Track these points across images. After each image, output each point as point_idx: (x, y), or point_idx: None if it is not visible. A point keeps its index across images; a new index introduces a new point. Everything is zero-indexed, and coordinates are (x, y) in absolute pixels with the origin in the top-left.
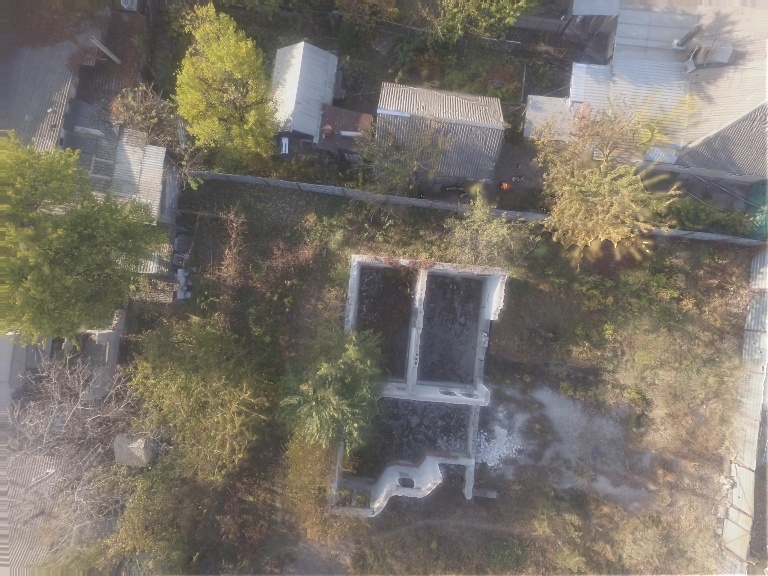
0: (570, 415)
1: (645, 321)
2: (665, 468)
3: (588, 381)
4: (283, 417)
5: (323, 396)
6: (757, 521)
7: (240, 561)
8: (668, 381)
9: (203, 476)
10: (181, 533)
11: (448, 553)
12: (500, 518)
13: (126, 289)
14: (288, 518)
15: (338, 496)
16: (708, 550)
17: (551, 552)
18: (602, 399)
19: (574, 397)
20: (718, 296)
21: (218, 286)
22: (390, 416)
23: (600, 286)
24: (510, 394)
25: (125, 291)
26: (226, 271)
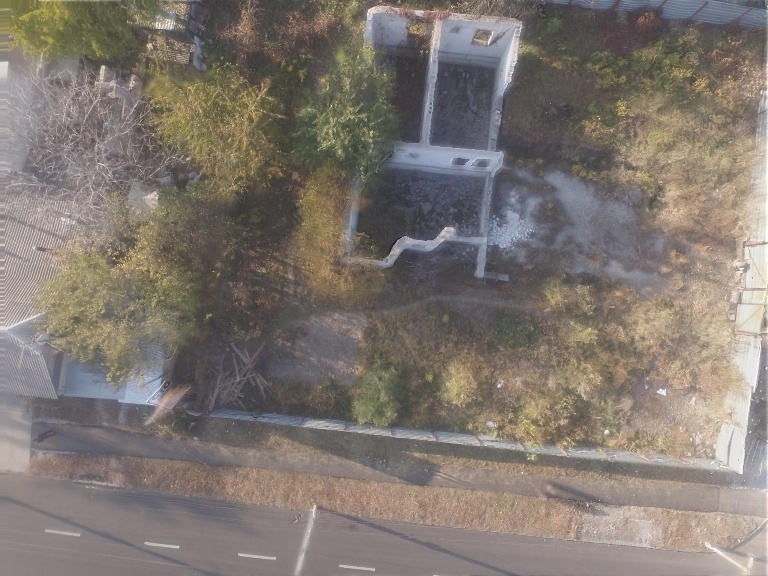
0: (582, 199)
1: (658, 99)
2: (678, 251)
3: (600, 167)
4: (296, 189)
5: (340, 99)
6: None
7: (252, 328)
8: (681, 164)
9: (219, 190)
10: (195, 275)
11: (460, 328)
12: (512, 294)
13: (143, 51)
14: (300, 290)
15: (352, 241)
16: None
17: (563, 331)
18: (615, 178)
19: (586, 178)
20: (731, 78)
21: (234, 45)
22: (402, 202)
23: (613, 65)
24: (522, 176)
25: (142, 55)
26: (242, 30)
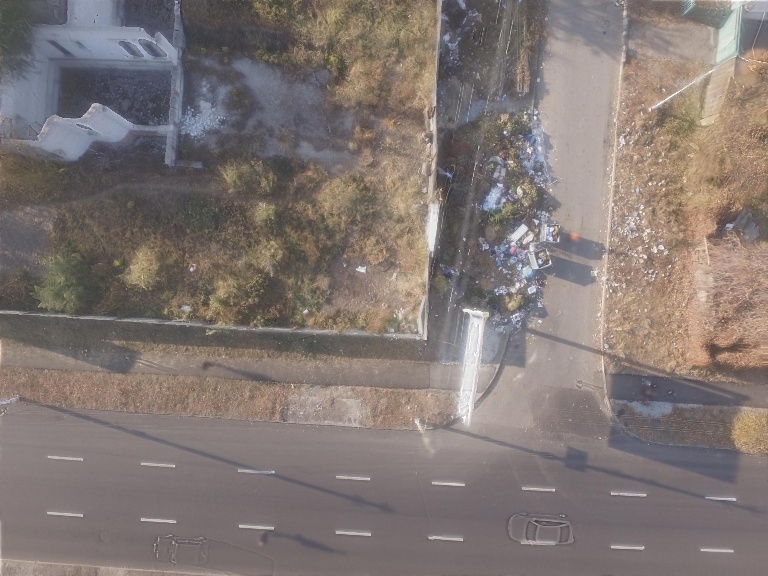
0: (271, 83)
1: None
2: (364, 127)
3: (289, 52)
4: None
5: None
6: (457, 172)
7: None
8: (363, 42)
9: None
10: None
11: (146, 213)
12: (196, 177)
13: None
14: None
15: None
16: (413, 207)
17: (250, 211)
18: (294, 59)
19: (269, 61)
20: None
21: None
22: (102, 101)
23: None
24: (209, 64)
25: None
26: None
